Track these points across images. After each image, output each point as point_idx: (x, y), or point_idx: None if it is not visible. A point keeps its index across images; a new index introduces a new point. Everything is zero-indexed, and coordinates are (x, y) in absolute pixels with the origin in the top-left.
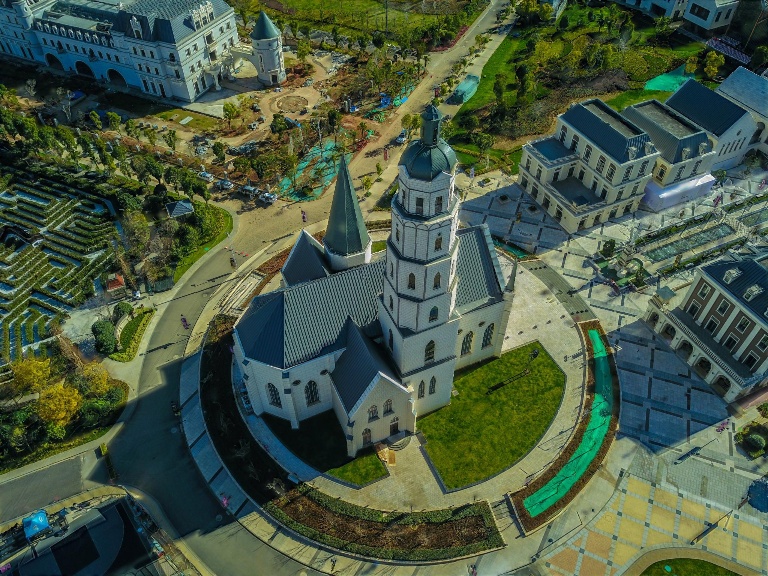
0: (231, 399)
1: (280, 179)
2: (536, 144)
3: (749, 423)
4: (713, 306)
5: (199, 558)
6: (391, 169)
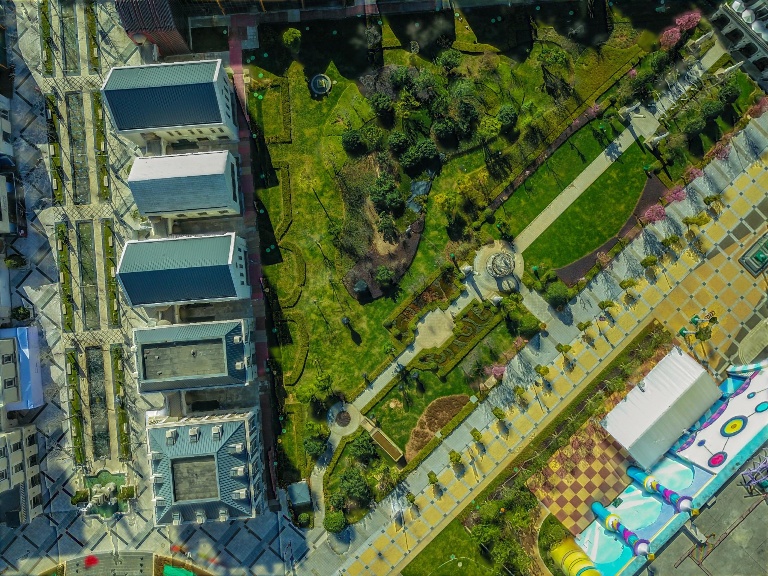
0: None
1: None
2: None
3: (288, 505)
4: None
5: None
6: None
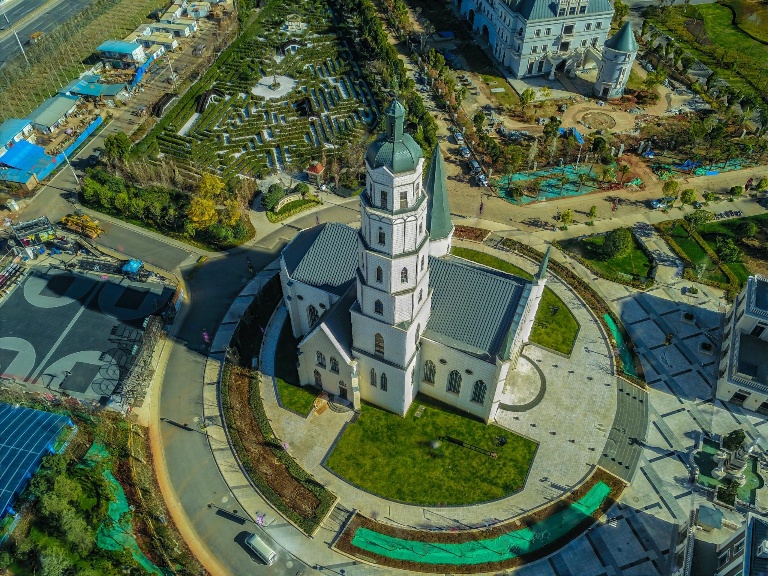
0: None
1: None
2: None
3: None
4: (733, 569)
5: (169, 356)
6: (613, 222)
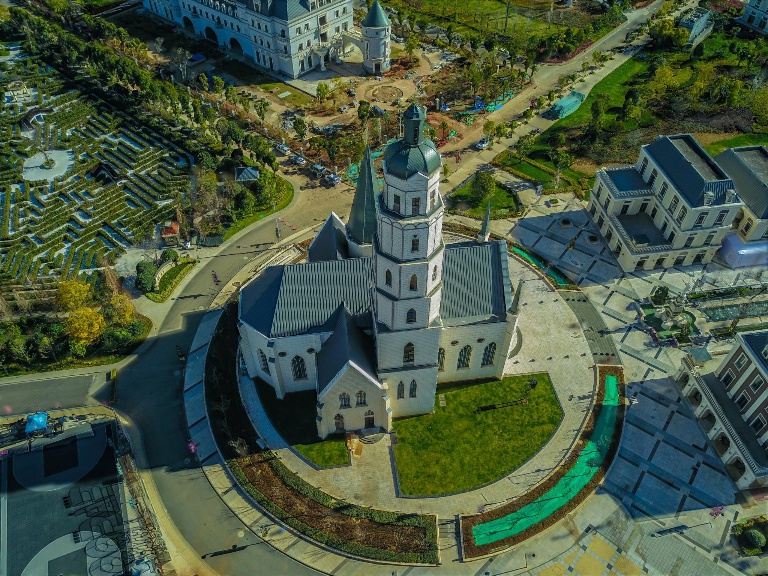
0: (233, 357)
1: (350, 164)
2: (612, 172)
3: (756, 517)
4: (747, 380)
5: (158, 491)
6: (461, 173)
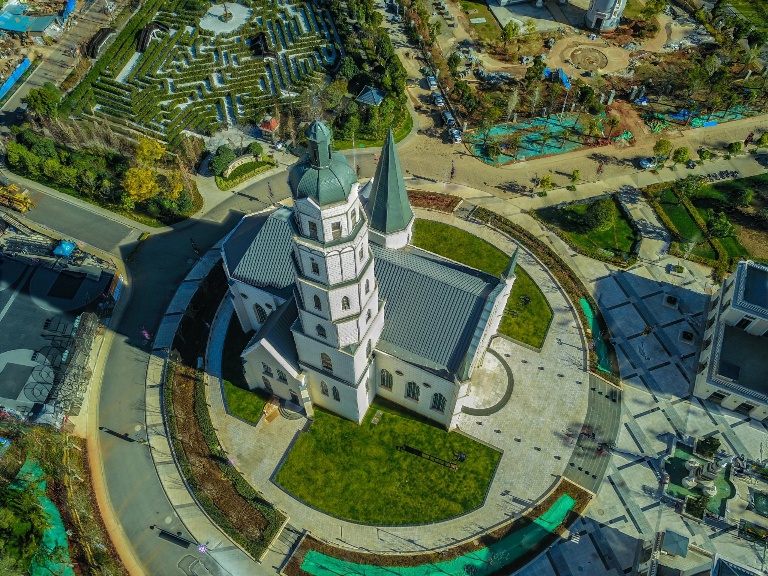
0: None
1: None
2: (760, 271)
3: None
4: None
5: (108, 354)
6: (597, 186)
